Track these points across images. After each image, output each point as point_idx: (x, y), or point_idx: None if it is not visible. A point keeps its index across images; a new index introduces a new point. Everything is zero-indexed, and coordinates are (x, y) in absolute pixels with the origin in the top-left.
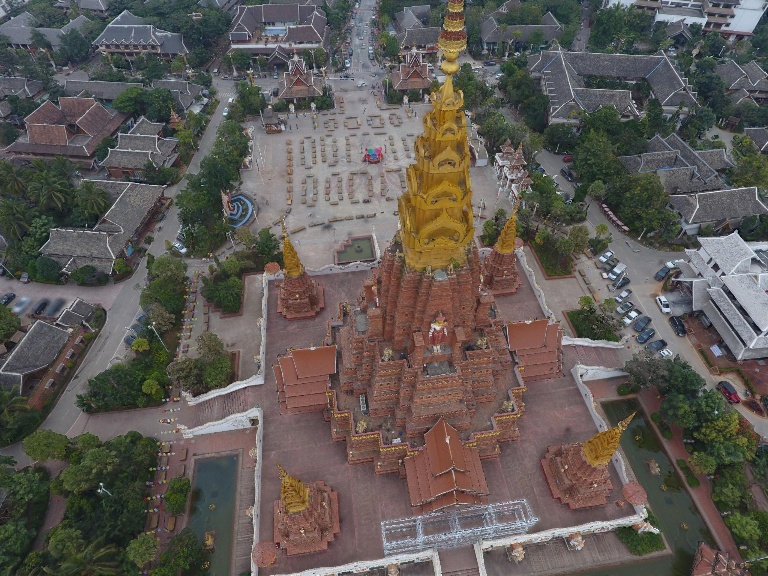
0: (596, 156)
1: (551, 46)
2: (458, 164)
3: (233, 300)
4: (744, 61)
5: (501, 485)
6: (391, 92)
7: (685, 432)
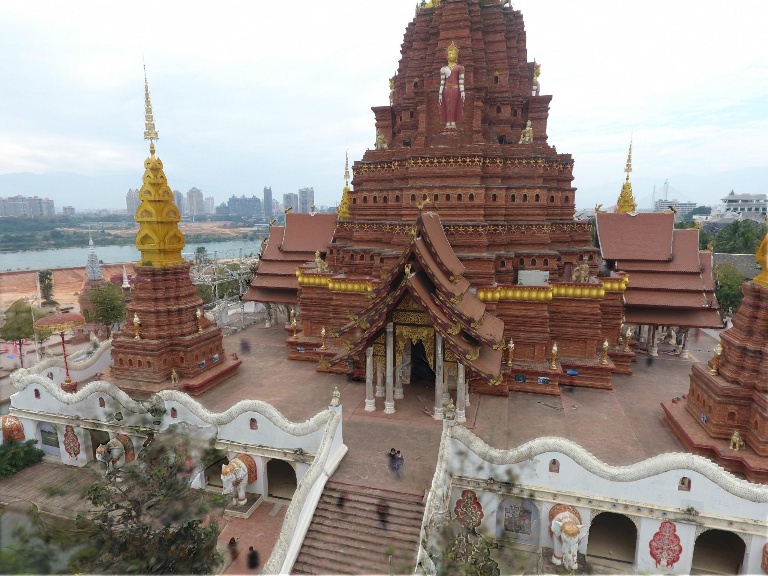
0: None
1: None
2: None
3: None
4: None
5: (254, 341)
6: None
7: None
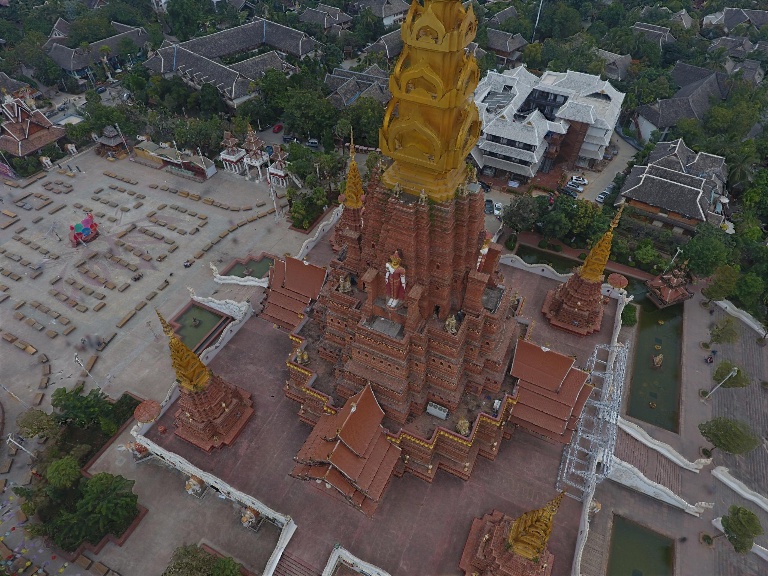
0: (309, 107)
1: (148, 51)
2: (473, 28)
3: (128, 500)
4: (313, 7)
5: None
6: (18, 162)
7: (561, 239)
